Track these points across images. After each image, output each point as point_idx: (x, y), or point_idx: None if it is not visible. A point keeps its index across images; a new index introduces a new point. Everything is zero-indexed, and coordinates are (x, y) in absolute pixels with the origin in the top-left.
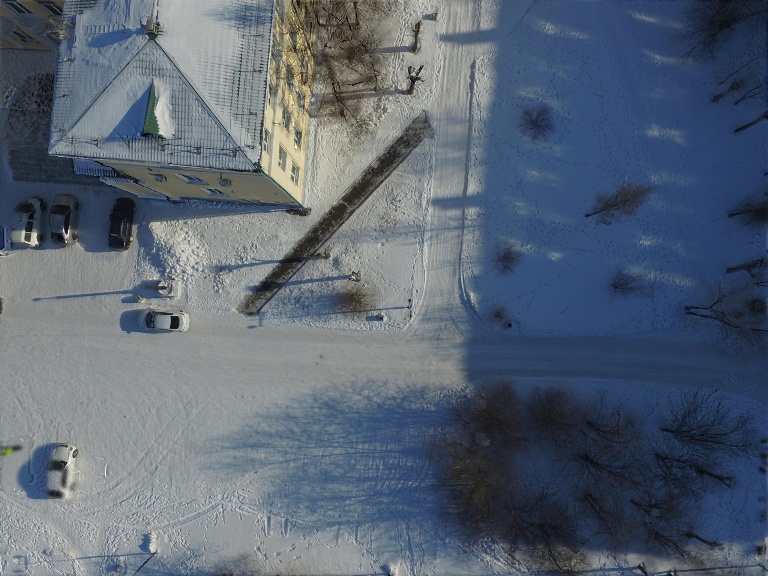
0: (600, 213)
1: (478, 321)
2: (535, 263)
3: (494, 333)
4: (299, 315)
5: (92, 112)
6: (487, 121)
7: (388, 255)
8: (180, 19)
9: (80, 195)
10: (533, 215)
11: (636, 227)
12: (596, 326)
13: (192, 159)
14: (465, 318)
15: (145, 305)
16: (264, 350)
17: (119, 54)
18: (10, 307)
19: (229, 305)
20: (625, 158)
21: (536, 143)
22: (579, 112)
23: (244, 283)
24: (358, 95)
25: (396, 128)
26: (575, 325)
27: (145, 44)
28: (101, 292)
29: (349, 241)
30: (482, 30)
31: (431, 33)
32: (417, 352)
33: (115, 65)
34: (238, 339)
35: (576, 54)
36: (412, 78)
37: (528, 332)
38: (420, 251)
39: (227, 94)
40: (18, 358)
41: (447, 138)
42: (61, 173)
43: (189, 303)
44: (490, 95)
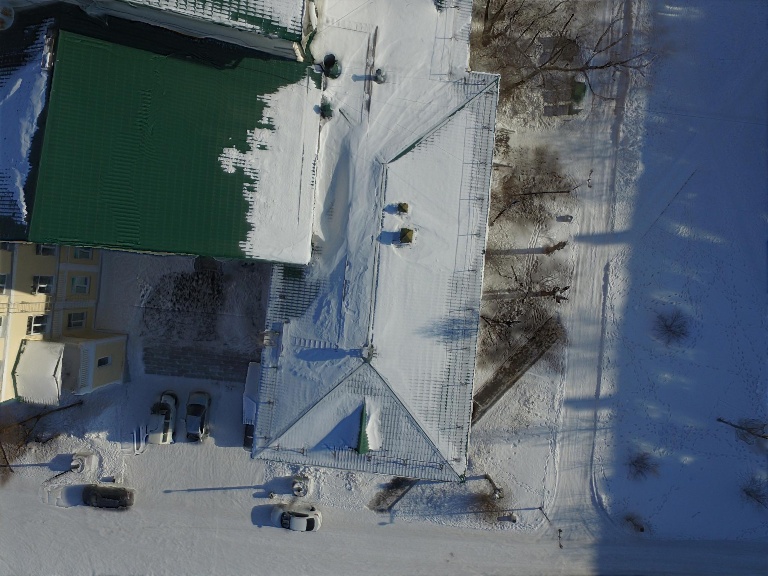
0: (740, 430)
1: (609, 523)
2: (667, 467)
3: (625, 535)
4: (431, 514)
5: (300, 424)
6: (620, 324)
7: (520, 456)
8: (393, 340)
9: (212, 390)
10: (665, 419)
11: (767, 432)
12: (727, 530)
13: (398, 469)
14: (596, 519)
15: (276, 500)
16: (395, 547)
17: (331, 372)
18: (141, 498)
19: (361, 502)
20: (758, 363)
21: (669, 347)
22: (713, 317)
23: (376, 481)
24: (491, 296)
25: (529, 329)
26: (706, 529)
27: (359, 366)
28: (233, 486)
29: (481, 441)
30: (616, 232)
31: (565, 235)
32: (547, 552)
33: (326, 382)
34: (369, 535)
35: (710, 258)
36: (556, 297)
37: (659, 535)
38: (552, 452)
39: (436, 409)
40: (149, 549)
41: (579, 339)
42: (194, 369)
43: (321, 500)
44: (623, 298)
